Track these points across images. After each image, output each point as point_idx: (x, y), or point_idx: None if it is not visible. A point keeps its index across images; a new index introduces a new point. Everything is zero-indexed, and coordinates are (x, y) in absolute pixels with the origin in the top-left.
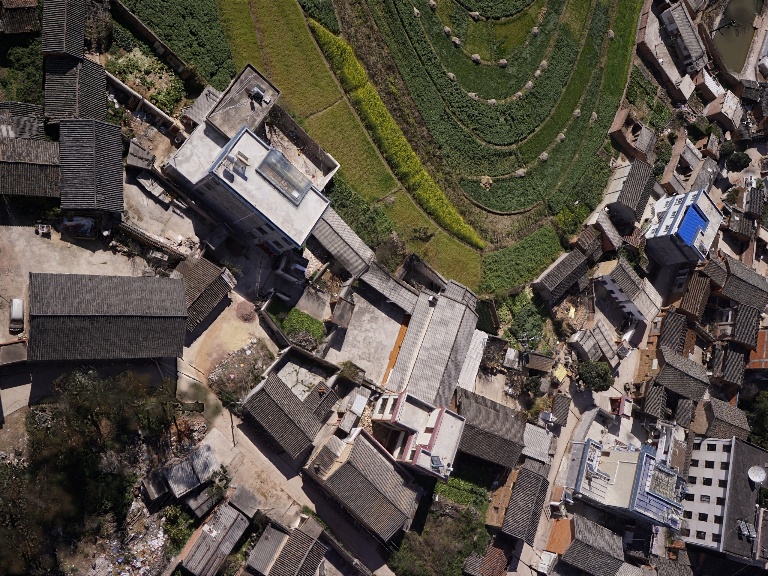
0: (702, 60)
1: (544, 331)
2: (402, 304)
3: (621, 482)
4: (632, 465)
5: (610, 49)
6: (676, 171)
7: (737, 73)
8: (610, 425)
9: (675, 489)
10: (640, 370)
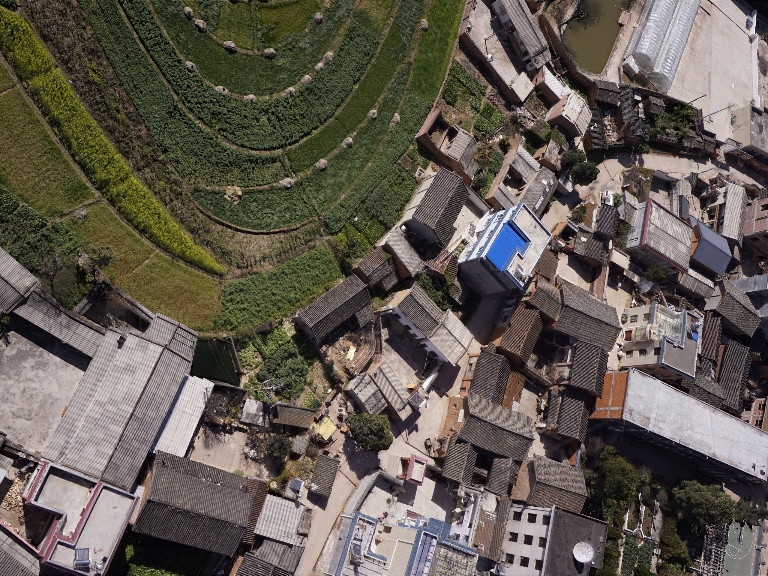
0: (542, 56)
1: (310, 376)
2: (80, 345)
3: (396, 568)
4: (409, 546)
5: (423, 41)
6: (506, 184)
7: (594, 73)
8: (395, 493)
9: (483, 571)
10: (446, 423)
